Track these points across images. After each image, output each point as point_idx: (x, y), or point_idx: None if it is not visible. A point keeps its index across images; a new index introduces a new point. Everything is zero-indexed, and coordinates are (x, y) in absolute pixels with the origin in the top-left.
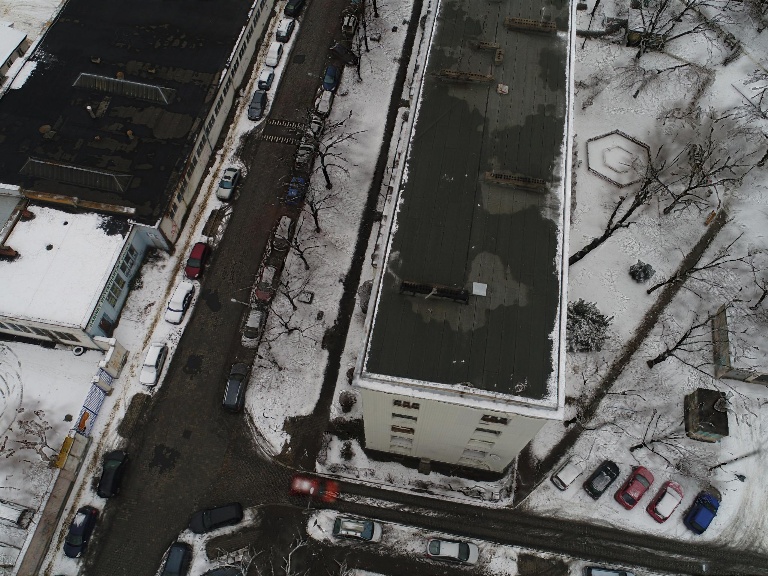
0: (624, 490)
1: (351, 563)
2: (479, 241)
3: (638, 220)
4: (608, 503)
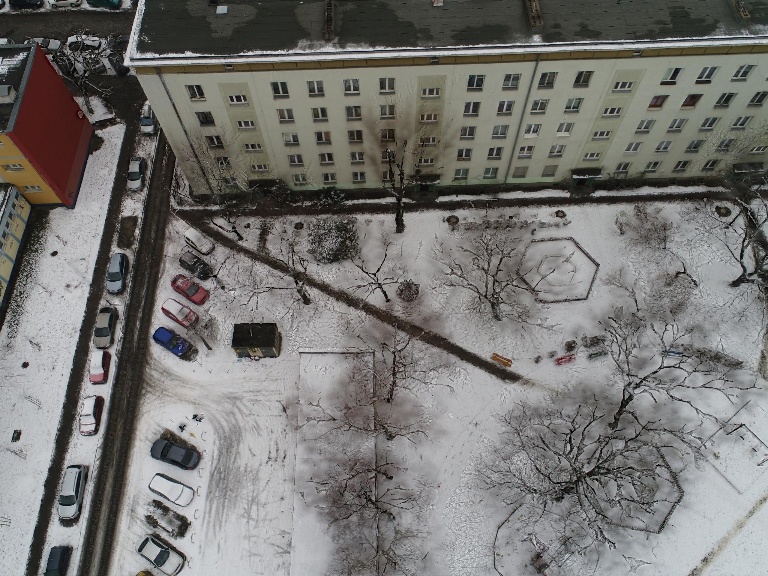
0: None
1: (130, 124)
2: (266, 6)
3: None
4: None
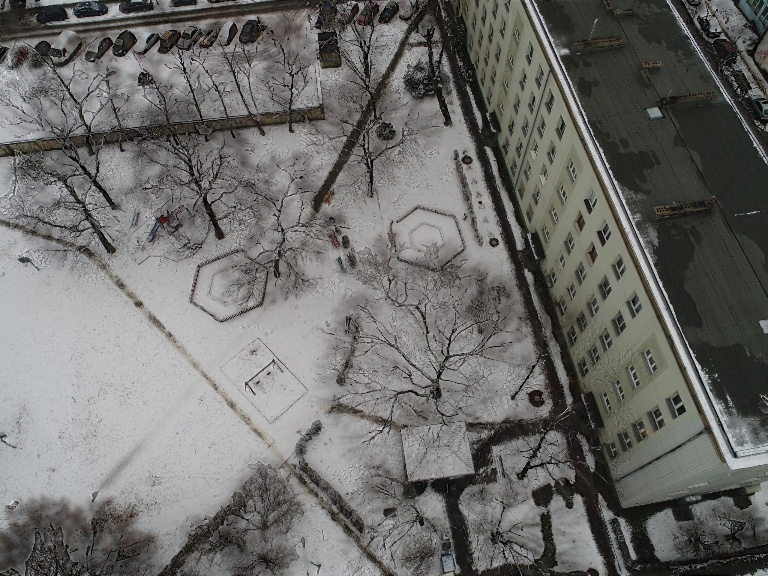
0: (376, 6)
1: None
2: None
3: (395, 181)
4: (382, 8)
